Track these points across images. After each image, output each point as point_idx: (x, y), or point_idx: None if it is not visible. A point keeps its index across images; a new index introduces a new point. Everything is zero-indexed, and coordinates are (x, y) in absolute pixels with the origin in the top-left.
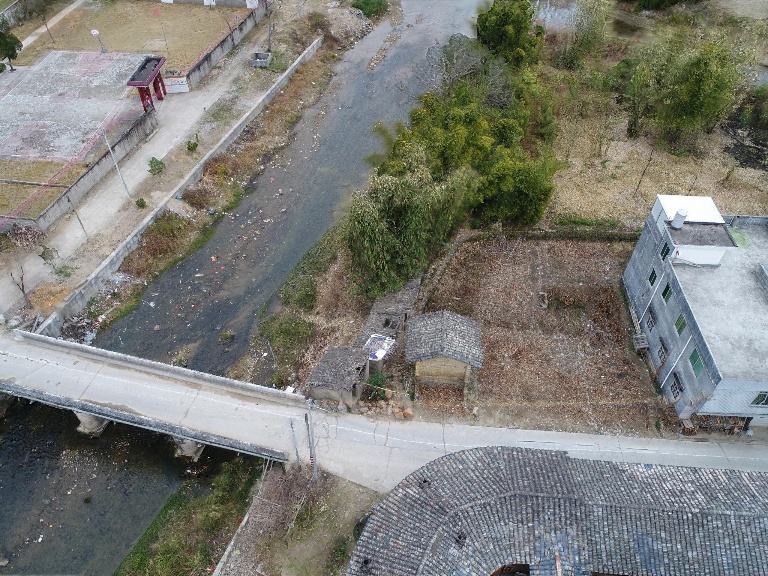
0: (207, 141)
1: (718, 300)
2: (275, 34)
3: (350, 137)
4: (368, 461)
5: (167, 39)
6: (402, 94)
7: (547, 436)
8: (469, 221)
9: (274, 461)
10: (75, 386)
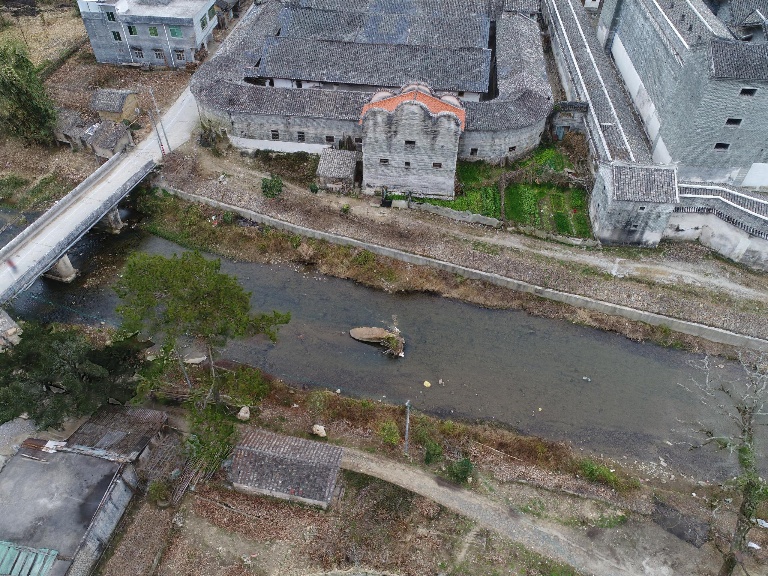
0: None
1: (149, 14)
2: None
3: None
4: (170, 141)
5: None
6: None
7: (184, 95)
8: None
9: (154, 169)
10: (43, 252)
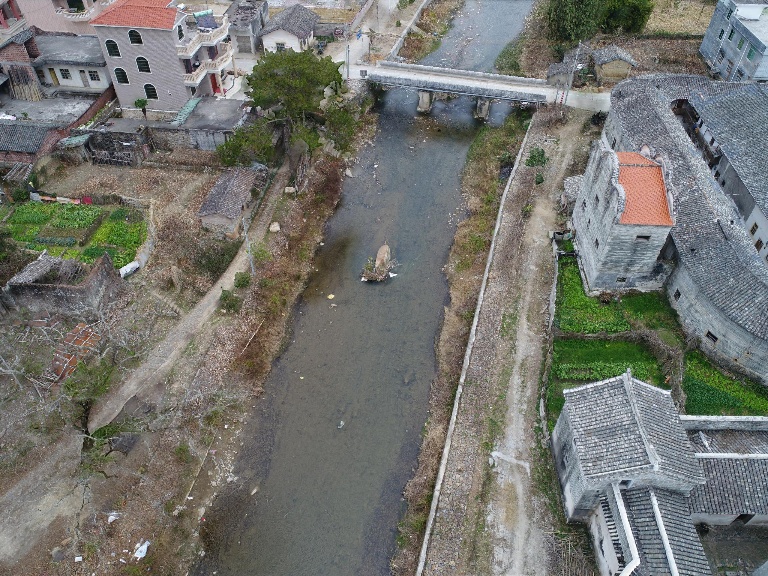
0: None
1: (760, 30)
2: None
3: (501, 3)
4: (587, 103)
5: None
6: None
7: None
8: (601, 30)
9: None
10: None
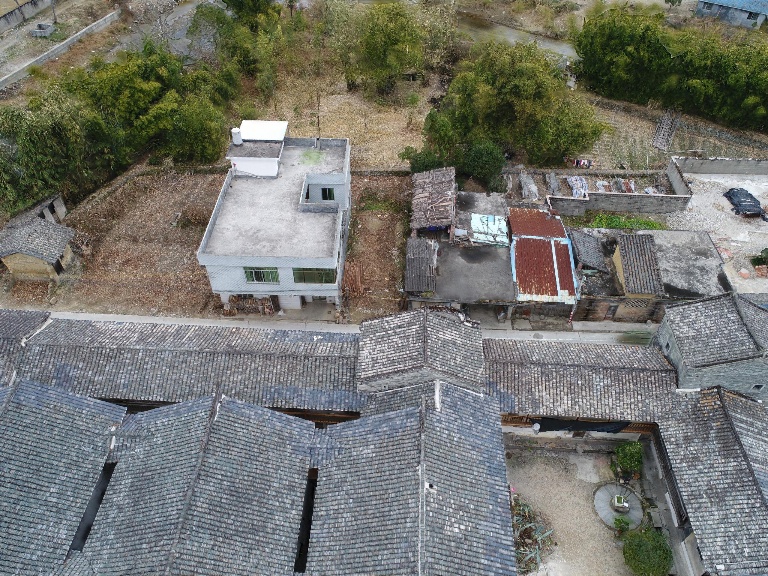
0: None
1: (256, 202)
2: (72, 9)
3: None
4: None
5: None
6: None
7: (103, 318)
8: (149, 159)
9: None
10: None
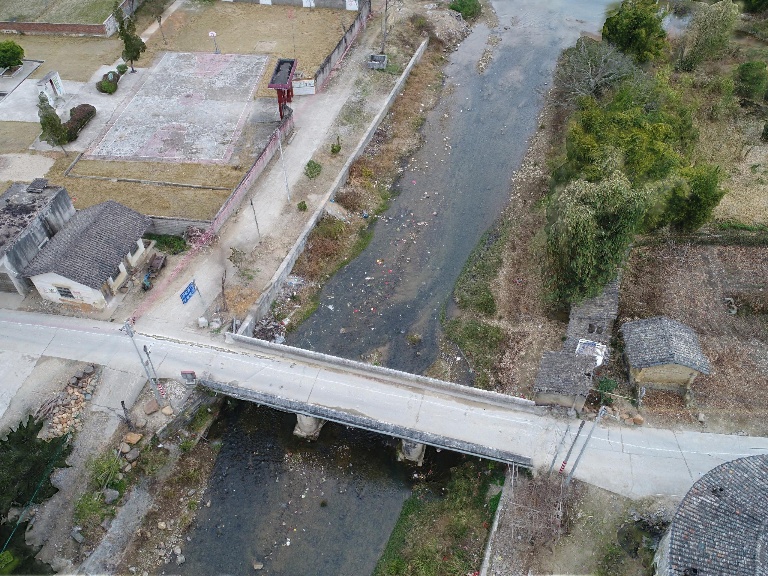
0: (347, 144)
1: None
2: (382, 36)
3: (479, 140)
4: (611, 467)
5: (276, 41)
6: (519, 97)
7: None
8: None
9: (519, 467)
10: (299, 390)
